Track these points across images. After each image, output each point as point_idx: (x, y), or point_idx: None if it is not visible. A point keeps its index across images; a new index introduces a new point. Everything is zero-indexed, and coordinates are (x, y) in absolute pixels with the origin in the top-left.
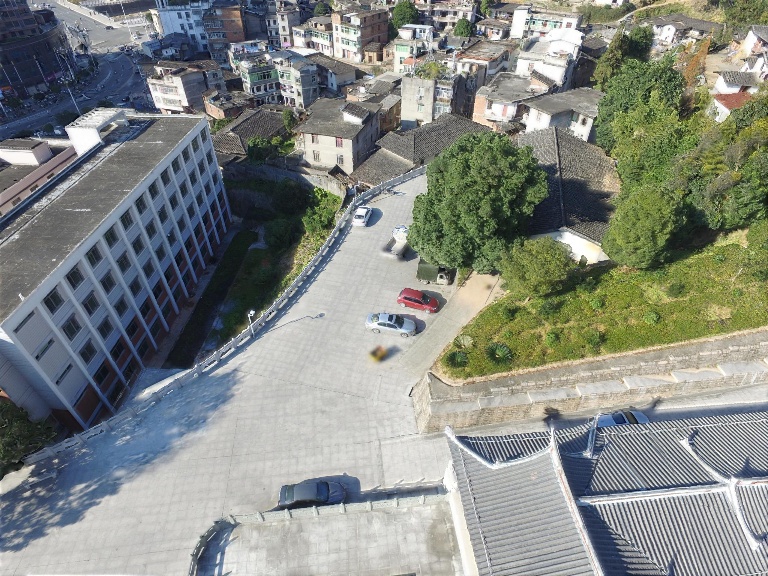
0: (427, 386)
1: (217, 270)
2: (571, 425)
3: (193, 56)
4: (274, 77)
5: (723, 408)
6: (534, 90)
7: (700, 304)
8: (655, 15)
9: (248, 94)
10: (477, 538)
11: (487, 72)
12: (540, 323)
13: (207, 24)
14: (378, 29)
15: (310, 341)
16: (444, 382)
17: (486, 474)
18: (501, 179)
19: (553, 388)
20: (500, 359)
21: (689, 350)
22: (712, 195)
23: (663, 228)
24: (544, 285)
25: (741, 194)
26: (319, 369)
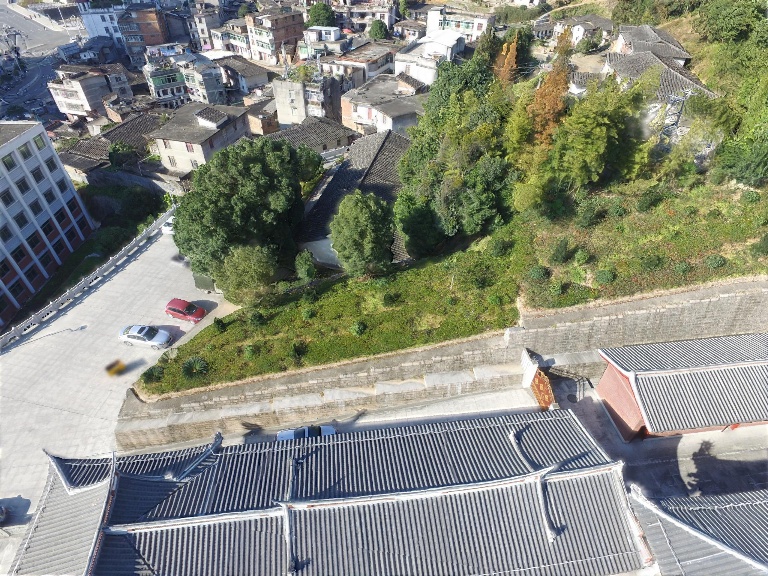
0: (122, 403)
1: (50, 280)
2: (267, 440)
3: (116, 59)
4: (180, 80)
5: (420, 420)
6: (402, 92)
7: (410, 313)
8: (572, 15)
9: (152, 98)
10: (12, 570)
11: (367, 74)
12: (250, 335)
13: (122, 27)
14: (293, 31)
15: (57, 355)
16: (140, 398)
17: (61, 500)
18: (238, 187)
19: (250, 403)
20: (192, 374)
21: (393, 361)
22: (449, 201)
23: (364, 237)
24: (247, 296)
25: (472, 200)
26: (50, 385)
